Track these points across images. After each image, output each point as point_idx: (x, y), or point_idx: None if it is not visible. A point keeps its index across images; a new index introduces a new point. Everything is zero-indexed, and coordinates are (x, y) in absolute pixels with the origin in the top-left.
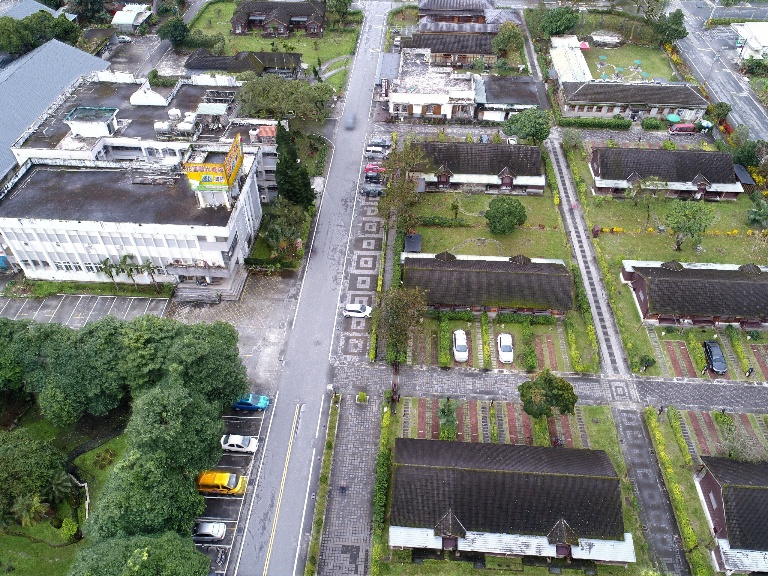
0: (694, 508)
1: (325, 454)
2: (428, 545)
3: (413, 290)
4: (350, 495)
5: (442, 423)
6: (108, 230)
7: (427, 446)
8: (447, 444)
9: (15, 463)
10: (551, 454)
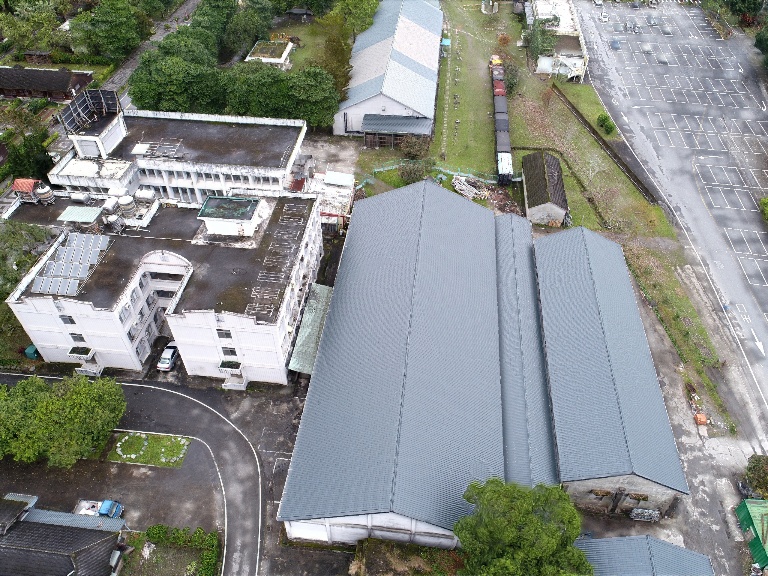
0: None
1: None
2: None
3: (0, 121)
4: None
5: (38, 103)
6: (203, 121)
7: (53, 85)
8: (42, 86)
9: None
10: None
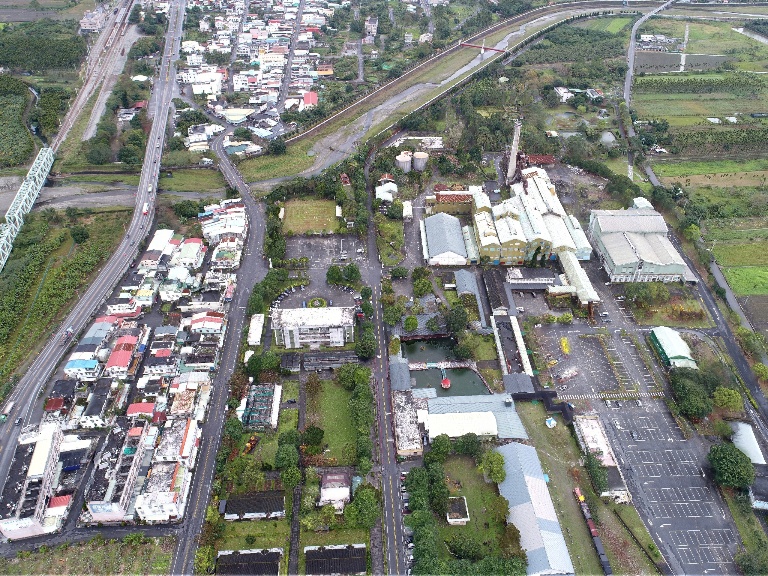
0: (282, 569)
1: (387, 572)
2: (356, 544)
3: None
4: (378, 561)
5: None
6: None
7: (357, 568)
8: (351, 570)
9: (462, 540)
10: (322, 570)
